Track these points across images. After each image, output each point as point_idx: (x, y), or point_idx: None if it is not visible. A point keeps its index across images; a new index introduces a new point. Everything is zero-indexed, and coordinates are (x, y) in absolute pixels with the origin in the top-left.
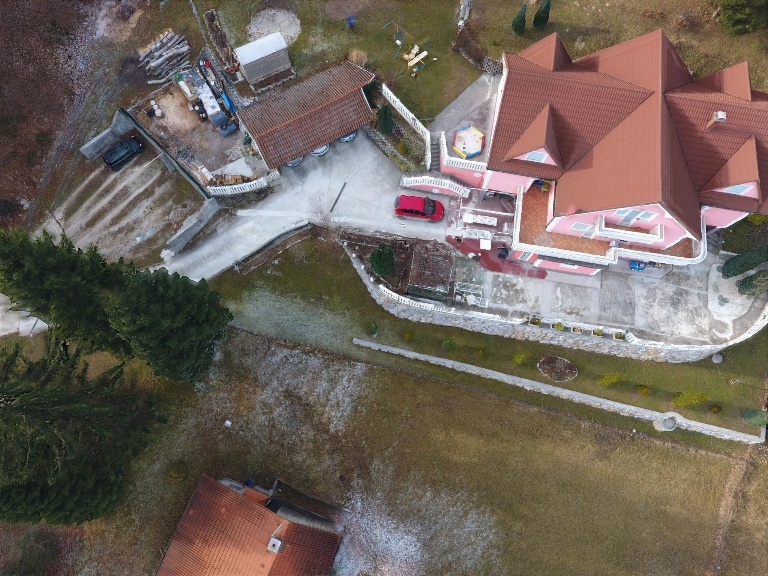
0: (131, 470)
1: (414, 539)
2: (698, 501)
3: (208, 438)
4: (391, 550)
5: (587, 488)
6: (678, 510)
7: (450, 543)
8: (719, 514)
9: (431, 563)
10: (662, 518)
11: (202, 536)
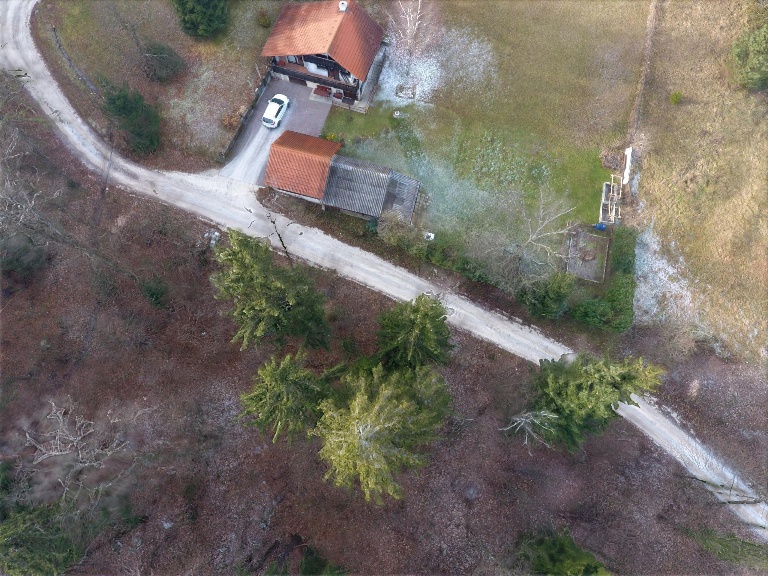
0: (231, 16)
1: (435, 61)
2: (632, 19)
3: (283, 1)
4: (419, 69)
5: (554, 20)
6: (618, 28)
7: (460, 63)
8: (646, 25)
9: (448, 78)
10: (608, 35)
11: (290, 28)
